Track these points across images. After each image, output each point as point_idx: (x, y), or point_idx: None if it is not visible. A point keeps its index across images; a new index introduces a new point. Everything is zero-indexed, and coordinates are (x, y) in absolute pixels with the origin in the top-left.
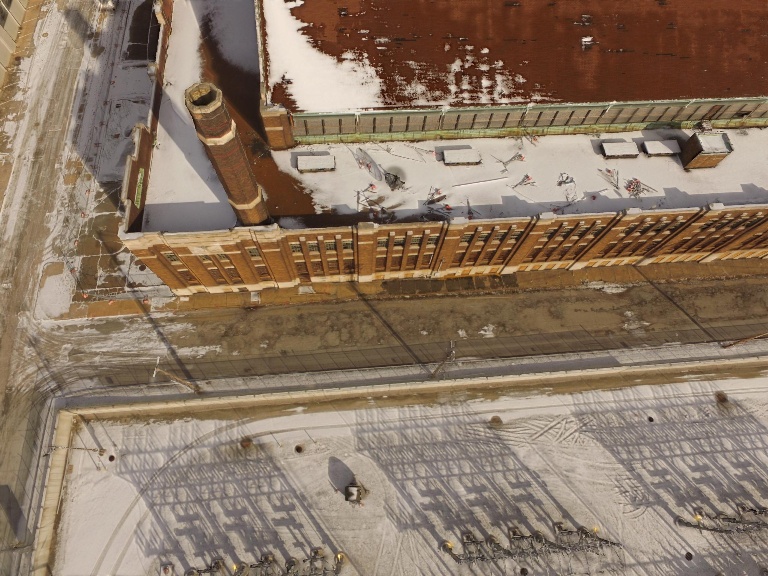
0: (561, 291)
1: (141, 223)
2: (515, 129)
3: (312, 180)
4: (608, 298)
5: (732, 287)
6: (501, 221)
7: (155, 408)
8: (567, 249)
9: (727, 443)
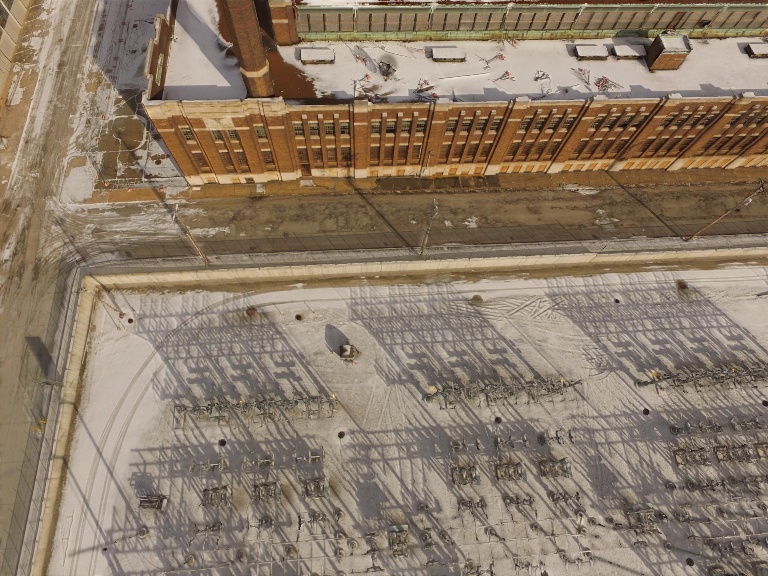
0: (539, 191)
1: None
2: (497, 32)
3: (314, 70)
4: (582, 198)
5: (696, 192)
6: (482, 104)
7: (169, 280)
8: (544, 146)
9: (685, 322)
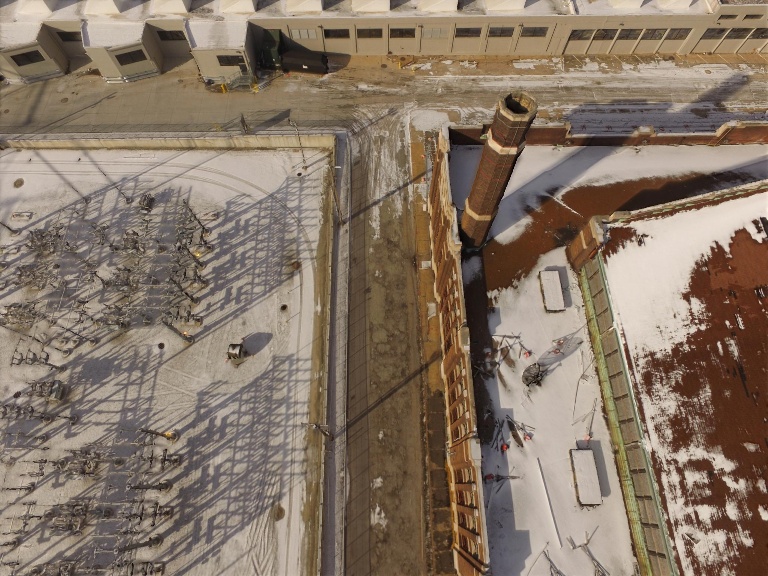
0: None
1: (468, 144)
2: (651, 575)
3: (530, 288)
4: None
5: None
6: (481, 515)
7: None
8: None
9: None
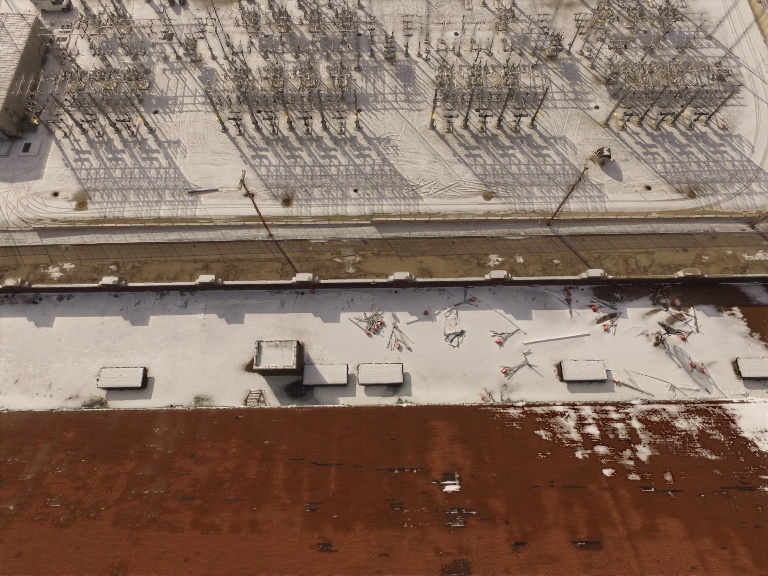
0: None
1: None
2: None
3: (755, 350)
4: None
5: None
6: (544, 277)
7: None
8: None
9: (299, 171)
